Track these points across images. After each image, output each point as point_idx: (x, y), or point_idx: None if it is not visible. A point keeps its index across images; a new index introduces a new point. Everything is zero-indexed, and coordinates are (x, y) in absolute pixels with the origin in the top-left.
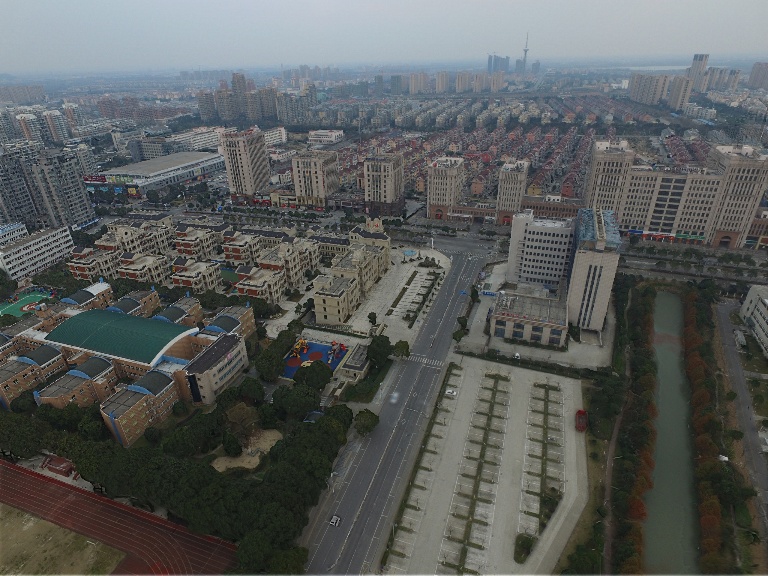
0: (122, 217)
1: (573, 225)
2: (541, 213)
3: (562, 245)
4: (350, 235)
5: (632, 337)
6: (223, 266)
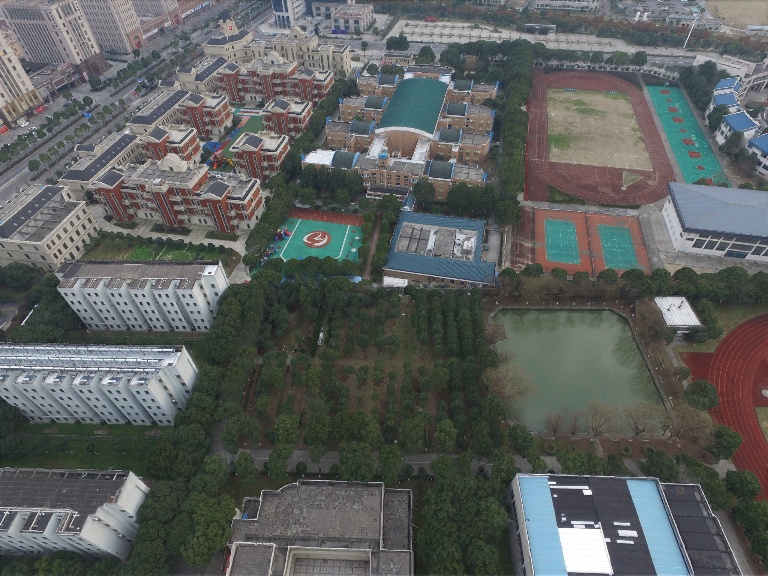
0: (6, 236)
1: None
2: (188, 1)
3: None
4: (225, 48)
5: None
6: (226, 136)
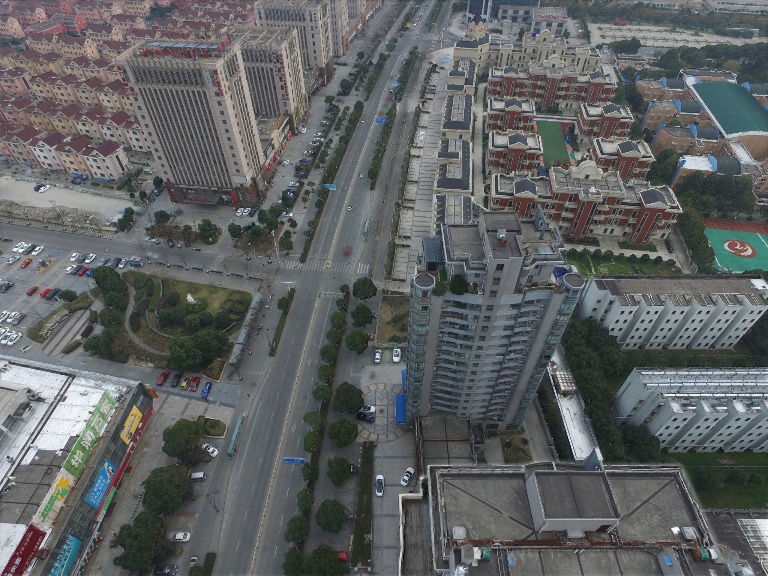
0: None
1: None
2: (369, 3)
3: None
4: None
5: None
6: None
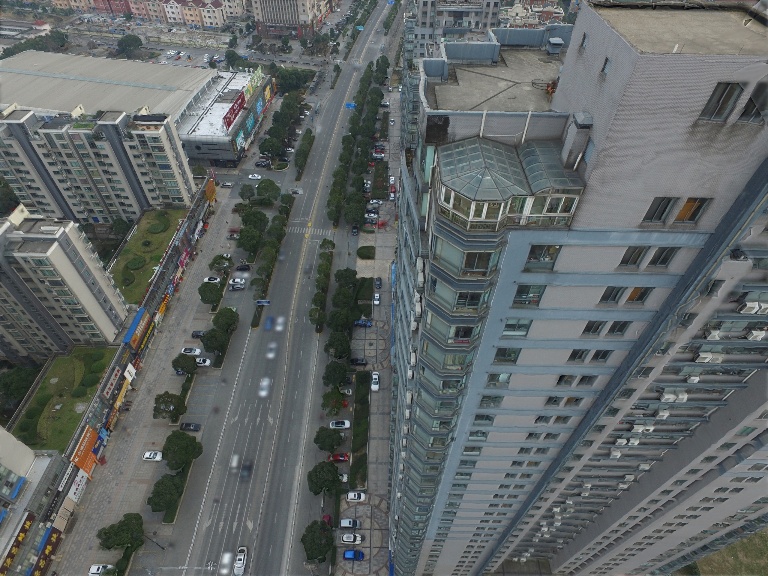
0: None
1: None
2: None
3: None
4: None
5: None
6: None
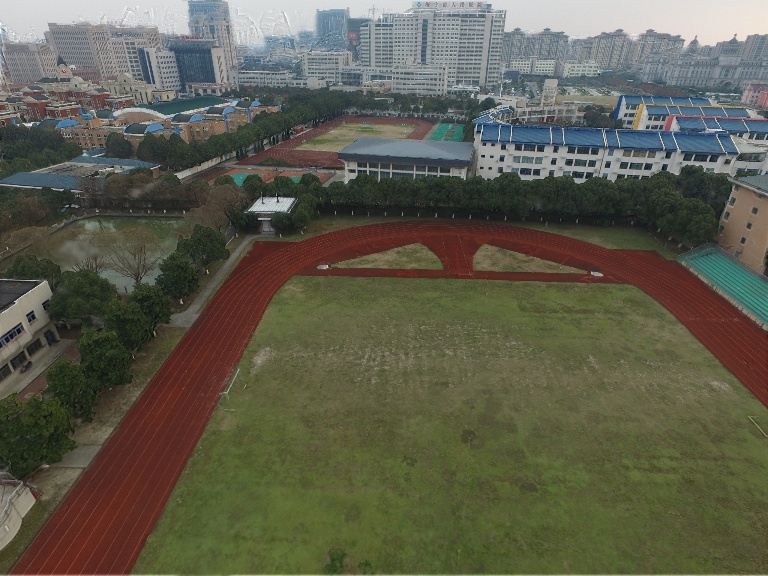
0: None
1: (171, 50)
2: None
3: (174, 63)
4: None
5: (240, 91)
6: None
